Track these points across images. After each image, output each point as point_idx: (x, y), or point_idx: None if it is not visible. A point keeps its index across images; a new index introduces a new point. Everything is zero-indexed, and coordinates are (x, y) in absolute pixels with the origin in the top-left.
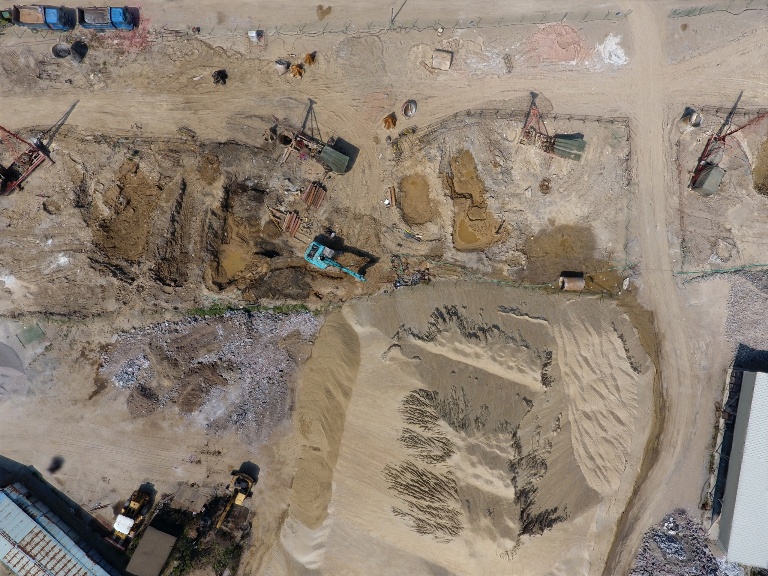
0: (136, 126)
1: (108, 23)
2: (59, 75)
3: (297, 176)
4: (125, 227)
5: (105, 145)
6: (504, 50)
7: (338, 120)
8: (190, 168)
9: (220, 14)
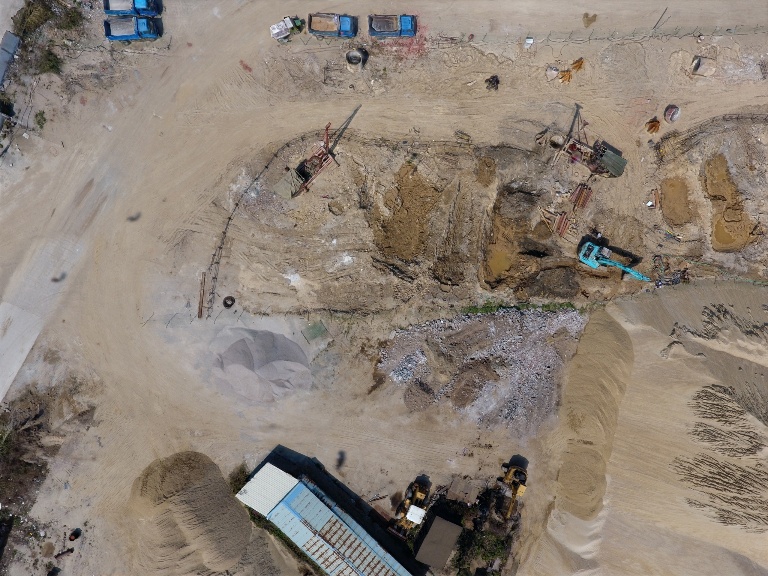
0: (414, 130)
1: (396, 31)
2: (342, 81)
3: (565, 178)
4: (399, 227)
5: (385, 148)
6: (759, 57)
7: (603, 124)
8: (467, 171)
9: (492, 22)
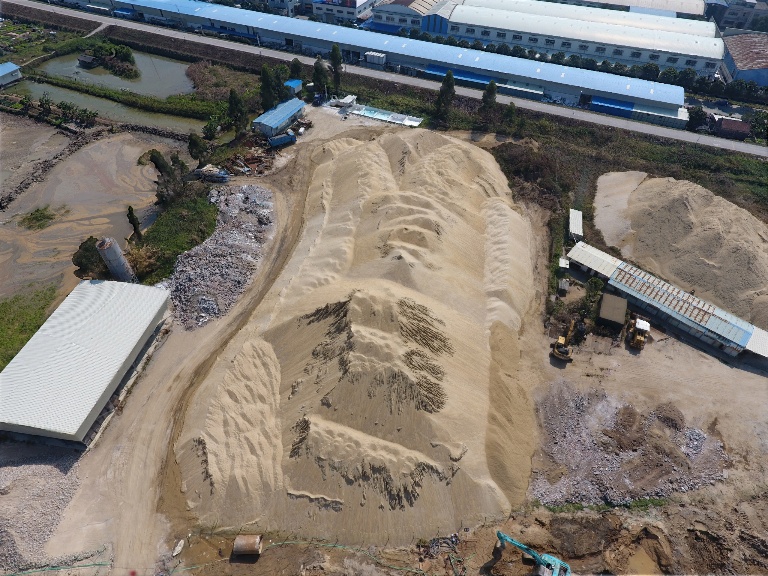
0: None
1: None
2: None
3: None
4: None
5: None
6: None
7: None
8: None
9: None
